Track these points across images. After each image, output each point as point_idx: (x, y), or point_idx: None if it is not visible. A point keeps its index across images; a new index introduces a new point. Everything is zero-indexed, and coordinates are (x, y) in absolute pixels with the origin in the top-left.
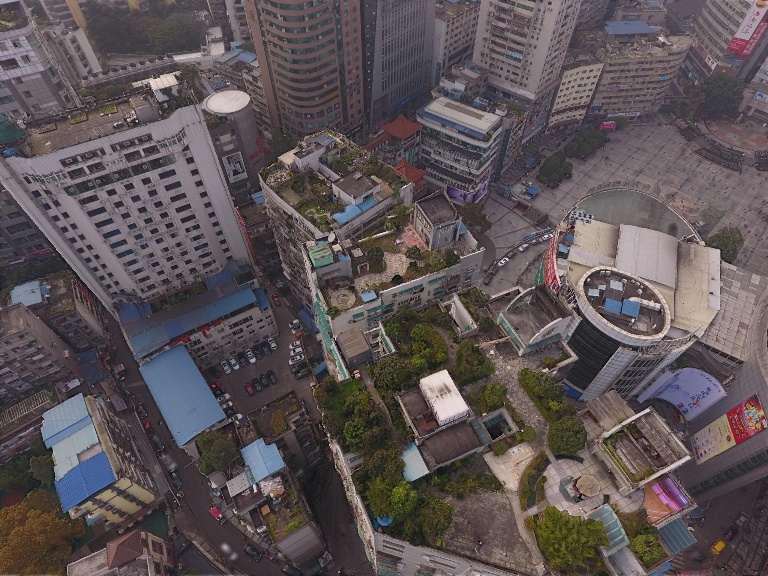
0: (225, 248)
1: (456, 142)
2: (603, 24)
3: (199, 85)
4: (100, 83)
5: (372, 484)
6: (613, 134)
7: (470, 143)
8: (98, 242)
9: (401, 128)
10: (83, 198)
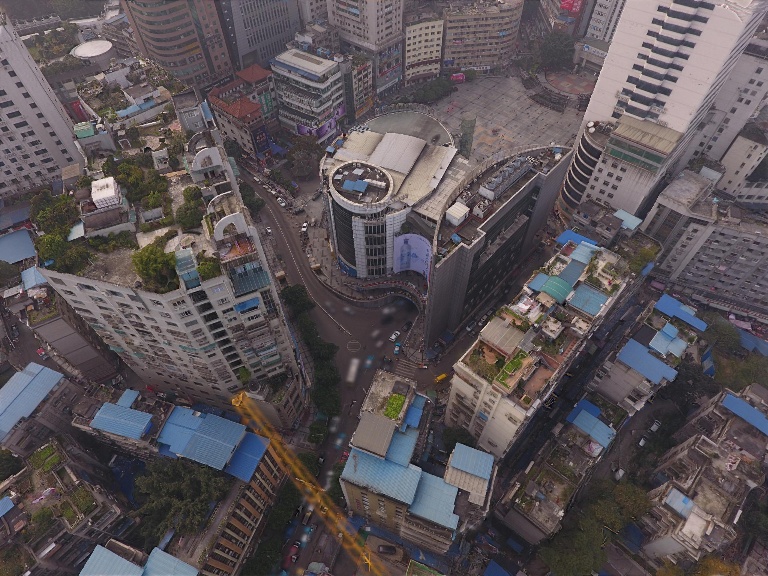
0: (68, 158)
1: (301, 86)
2: None
3: None
4: None
5: None
6: (463, 85)
7: (310, 85)
8: None
9: (250, 73)
10: None
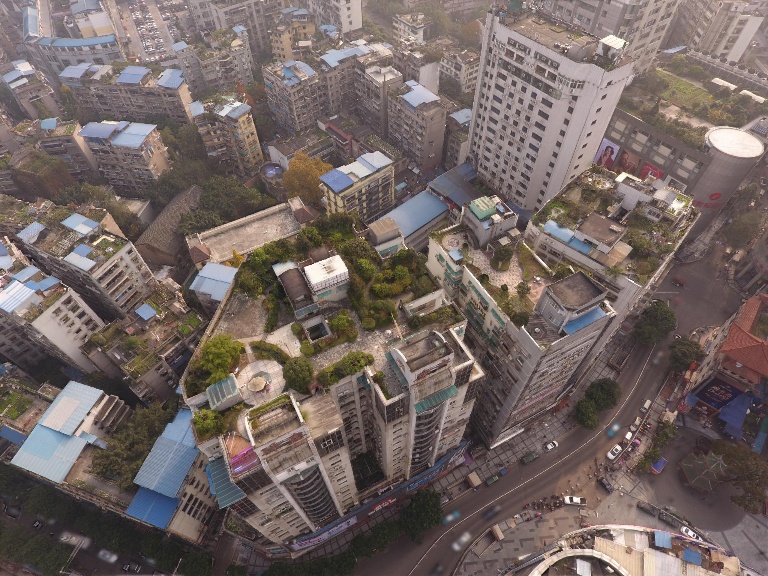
0: (540, 199)
1: None
2: None
3: None
4: (700, 61)
5: None
6: None
7: None
8: None
9: None
10: (501, 72)
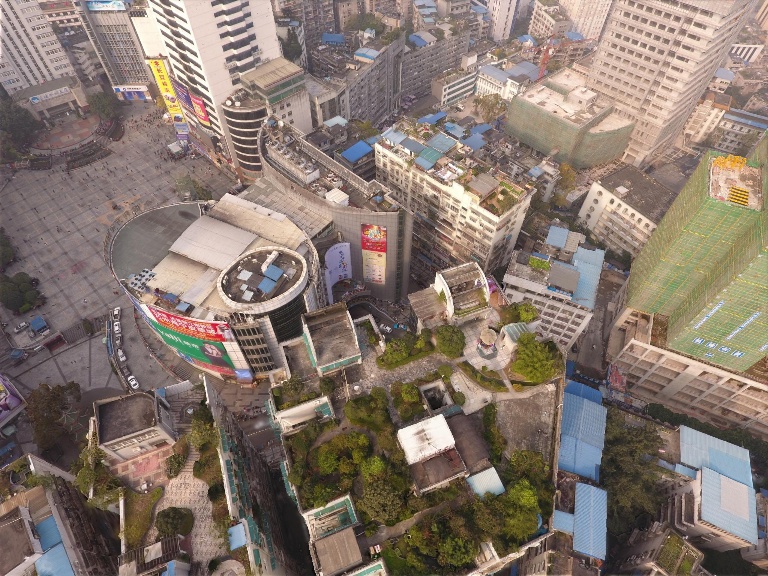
0: None
1: None
2: None
3: None
4: None
5: (509, 531)
6: None
7: None
8: None
9: None
10: None
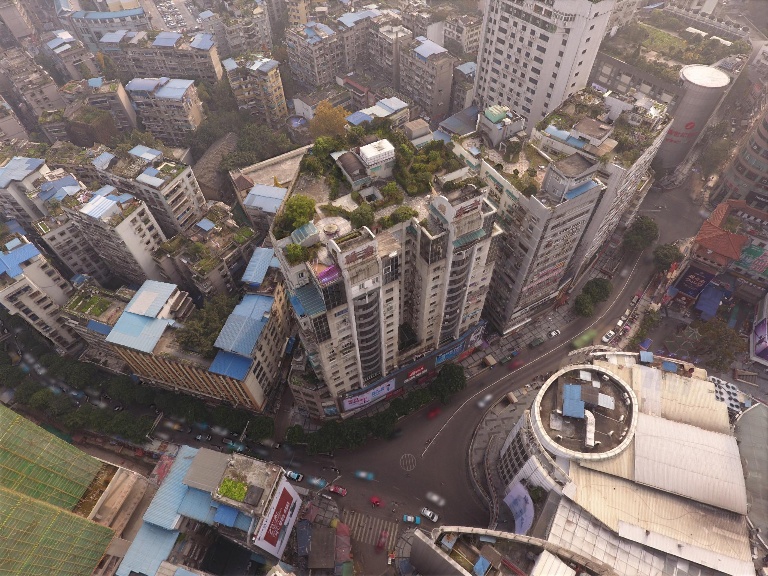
0: None
1: None
2: None
3: None
4: (676, 14)
5: None
6: None
7: None
8: None
9: None
10: (504, 16)
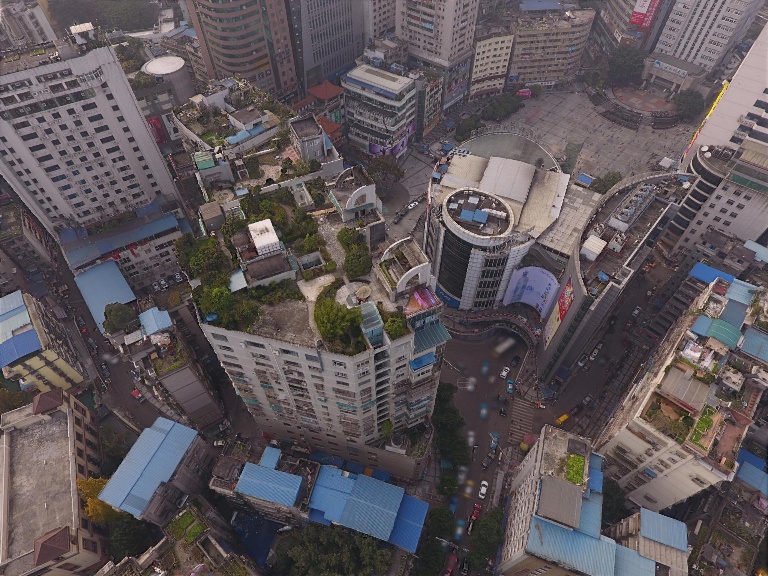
0: (153, 182)
1: (375, 103)
2: (519, 2)
3: (143, 54)
4: None
5: None
6: (529, 101)
7: (386, 103)
8: (34, 166)
9: (324, 90)
10: (16, 123)
